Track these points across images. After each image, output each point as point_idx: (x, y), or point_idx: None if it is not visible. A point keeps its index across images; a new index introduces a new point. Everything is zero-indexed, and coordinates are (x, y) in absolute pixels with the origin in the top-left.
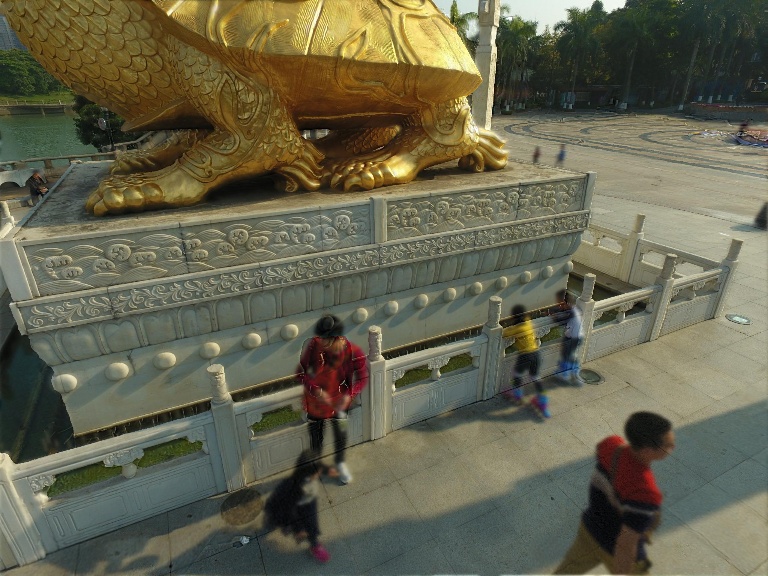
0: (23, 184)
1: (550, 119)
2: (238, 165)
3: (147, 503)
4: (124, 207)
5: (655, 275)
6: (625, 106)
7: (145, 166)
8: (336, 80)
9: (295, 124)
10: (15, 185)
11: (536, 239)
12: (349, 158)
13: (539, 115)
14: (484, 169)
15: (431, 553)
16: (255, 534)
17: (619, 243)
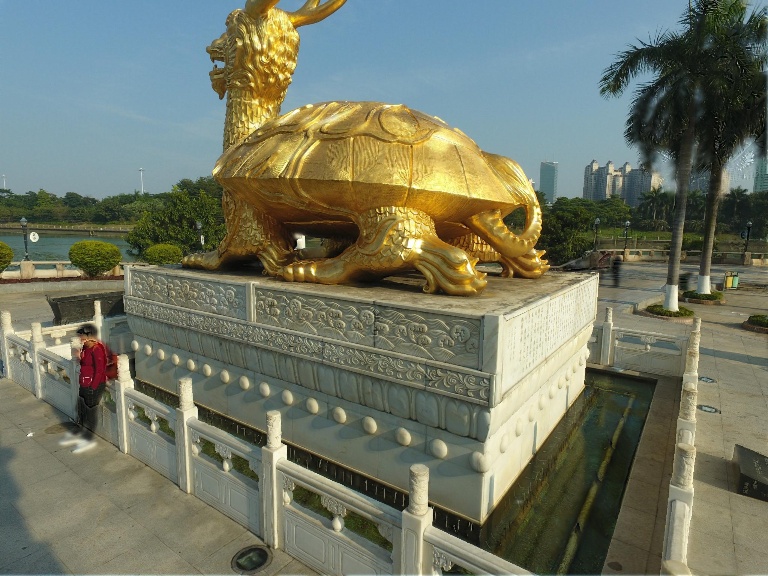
0: None
1: None
2: (226, 248)
3: (58, 400)
4: (187, 264)
5: None
6: None
7: (298, 256)
8: None
9: (265, 225)
10: None
11: (399, 383)
12: None
13: None
14: (440, 292)
15: None
16: (35, 437)
17: None
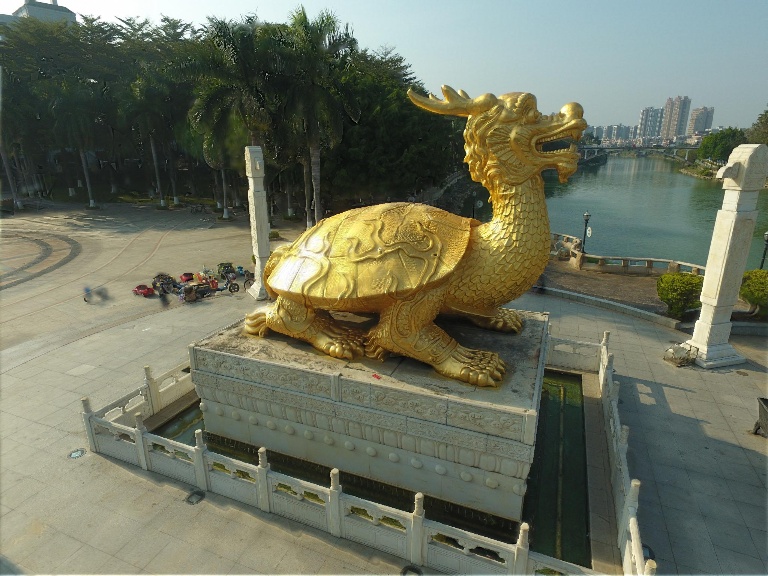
0: None
1: None
2: None
3: None
4: None
5: None
6: None
7: None
8: None
9: None
10: None
11: None
12: None
13: None
14: None
15: None
16: None
17: None
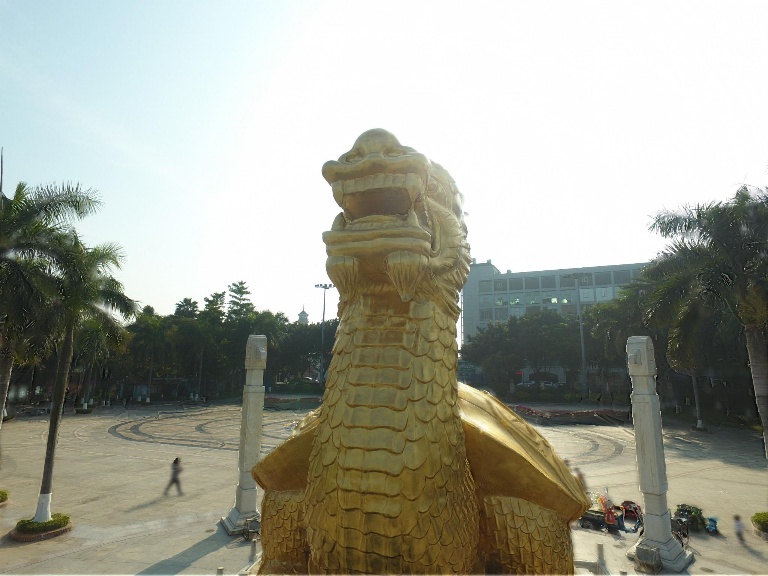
0: None
1: (140, 416)
2: None
3: None
4: None
5: None
6: (204, 399)
7: None
8: None
9: None
10: None
11: None
12: None
13: (127, 413)
14: None
15: None
16: None
17: None
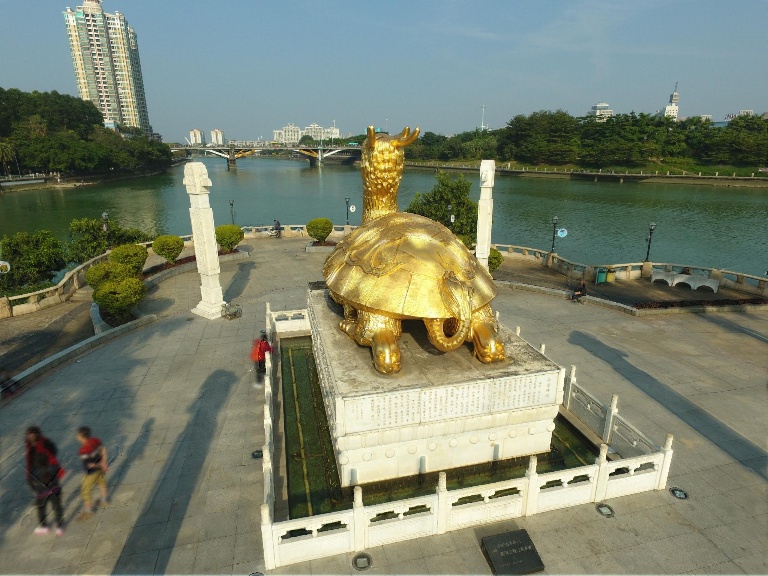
0: (695, 288)
1: None
2: None
3: None
4: None
5: None
6: None
7: None
8: None
9: None
10: (688, 286)
11: None
12: None
13: None
14: None
15: (222, 394)
16: None
17: None
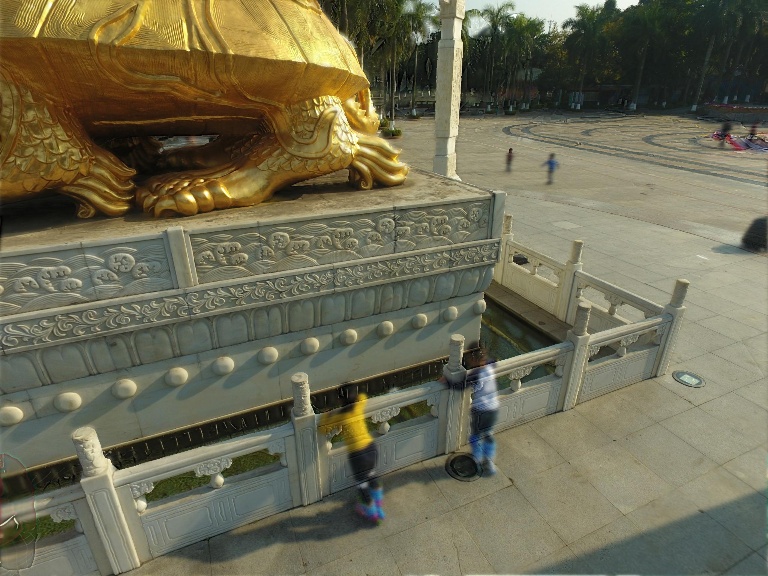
0: None
1: (555, 120)
2: None
3: None
4: None
5: (593, 316)
6: (634, 107)
7: None
8: (103, 73)
9: (74, 131)
10: None
11: (426, 276)
12: (180, 173)
13: (543, 116)
14: (374, 185)
15: None
16: None
17: (555, 274)
